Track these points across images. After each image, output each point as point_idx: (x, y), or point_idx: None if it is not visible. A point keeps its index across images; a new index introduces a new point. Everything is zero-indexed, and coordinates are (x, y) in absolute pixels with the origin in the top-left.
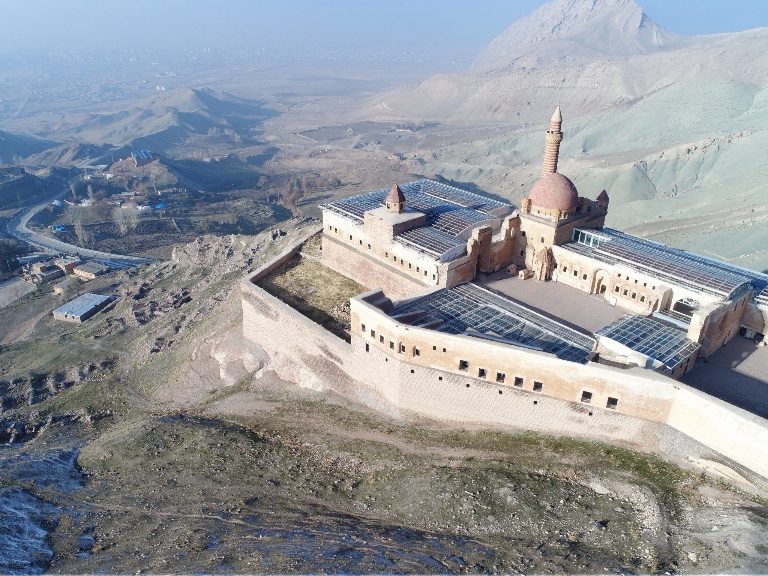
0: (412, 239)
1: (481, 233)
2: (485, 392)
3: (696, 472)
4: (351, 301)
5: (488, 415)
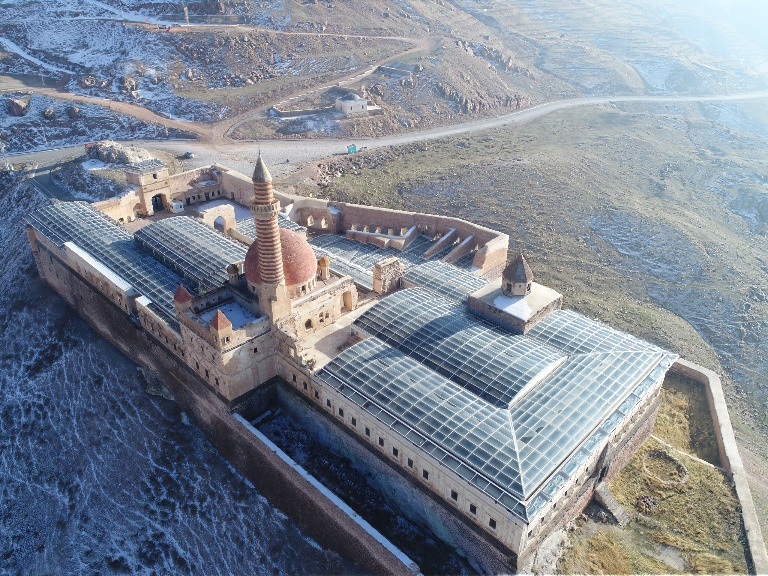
0: None
1: None
2: None
3: None
4: None
5: None
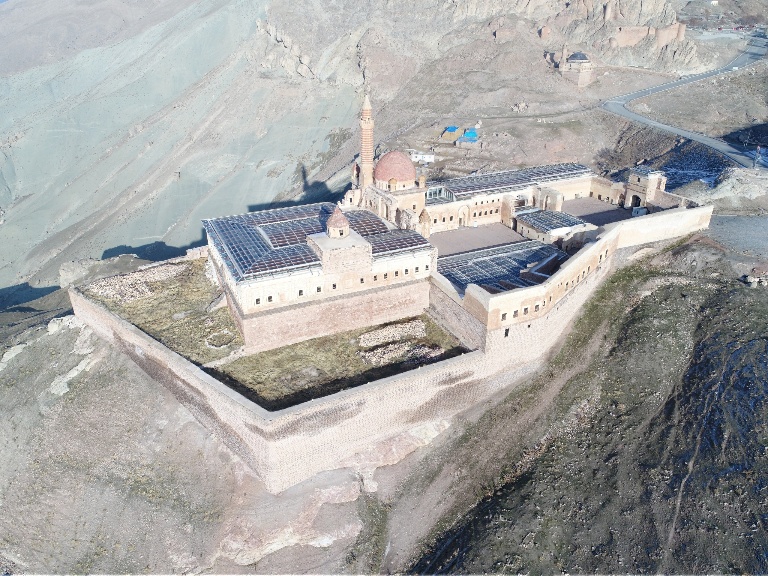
0: (388, 248)
1: None
2: (572, 297)
3: (635, 262)
4: (491, 301)
5: (571, 313)
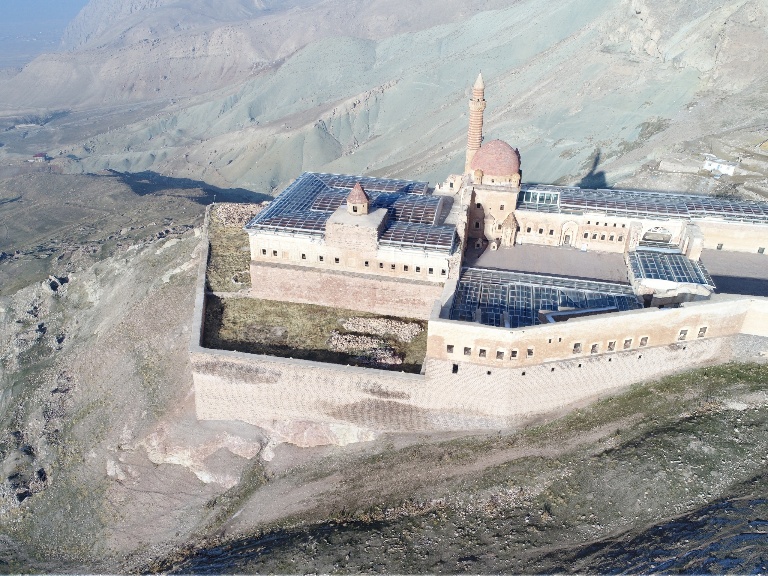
0: (401, 239)
1: None
2: (596, 365)
3: None
4: (430, 324)
5: (596, 386)
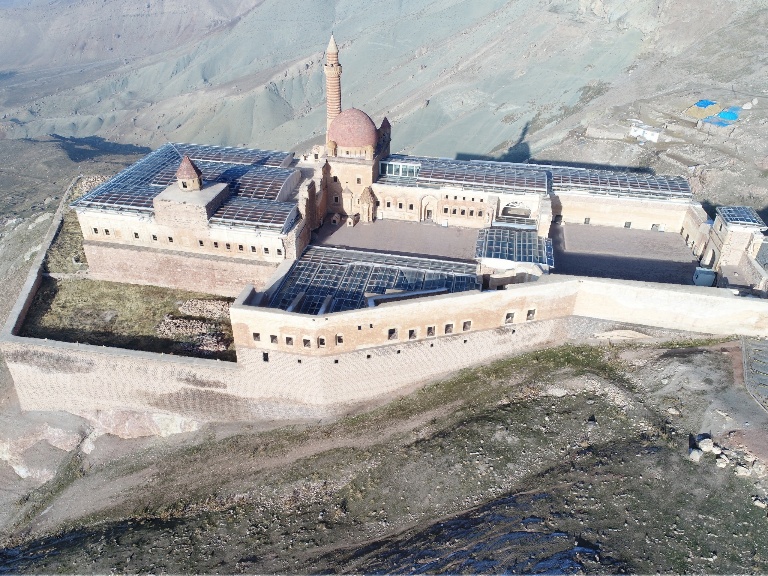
0: (234, 216)
1: (309, 189)
2: (417, 351)
3: (605, 344)
4: (231, 311)
5: (421, 372)
